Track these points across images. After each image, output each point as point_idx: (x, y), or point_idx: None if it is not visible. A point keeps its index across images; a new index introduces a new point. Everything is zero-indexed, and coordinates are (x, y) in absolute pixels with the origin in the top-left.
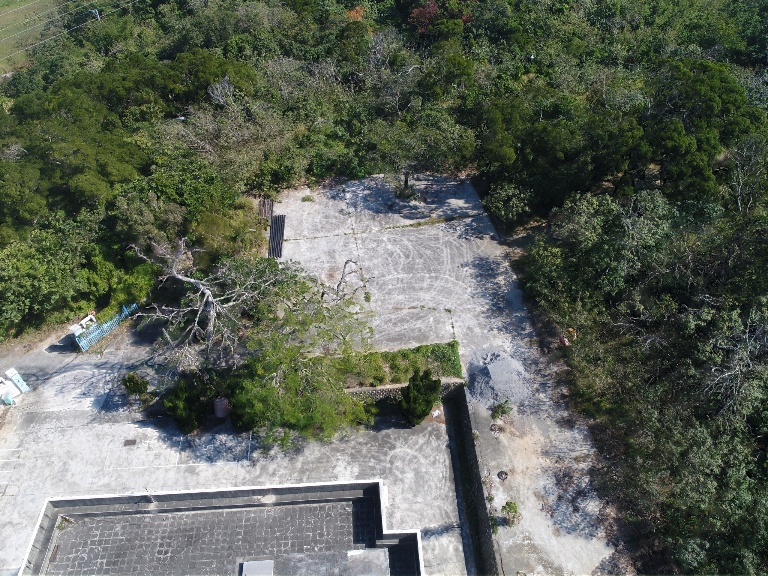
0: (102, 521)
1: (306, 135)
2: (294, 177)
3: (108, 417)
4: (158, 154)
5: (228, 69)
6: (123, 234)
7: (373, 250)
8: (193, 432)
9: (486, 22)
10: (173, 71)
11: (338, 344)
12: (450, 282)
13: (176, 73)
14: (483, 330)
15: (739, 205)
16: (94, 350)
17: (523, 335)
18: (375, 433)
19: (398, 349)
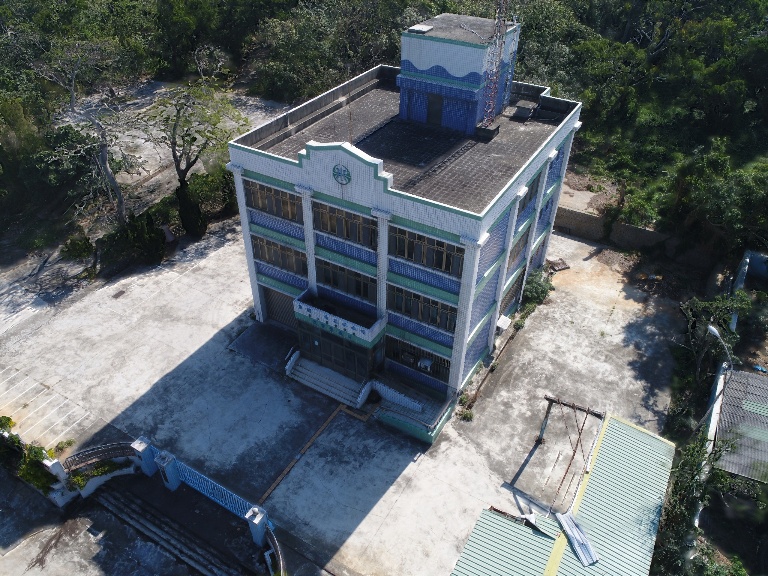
0: (270, 150)
1: None
2: None
3: (68, 301)
4: None
5: None
6: None
7: None
8: (163, 259)
9: (21, 11)
10: None
11: None
12: None
13: None
14: None
15: (338, 7)
16: None
17: None
18: None
19: None
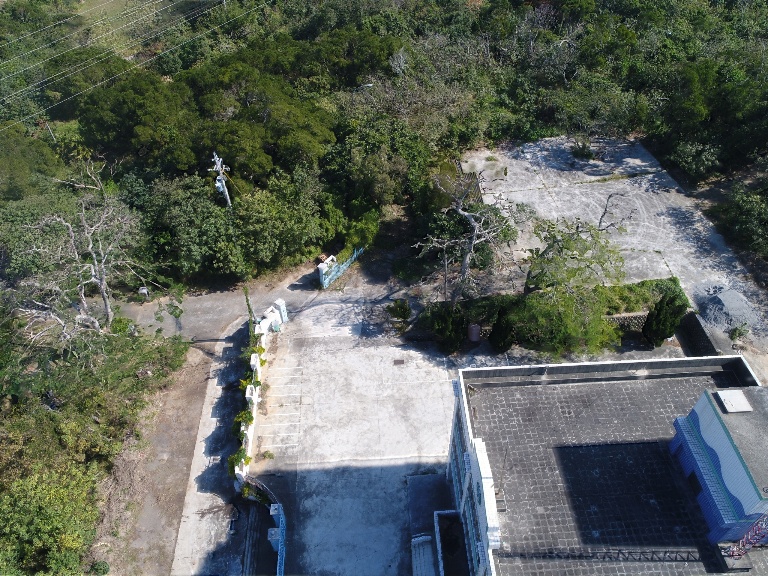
0: (501, 390)
1: (479, 102)
2: (475, 139)
3: (371, 342)
4: (349, 118)
5: (392, 43)
6: (358, 183)
7: (569, 202)
8: (453, 354)
9: (611, 2)
10: (334, 46)
11: (590, 273)
12: (652, 228)
13: (338, 48)
14: (697, 268)
15: None
16: (334, 288)
17: (736, 272)
18: (620, 354)
19: (623, 284)
